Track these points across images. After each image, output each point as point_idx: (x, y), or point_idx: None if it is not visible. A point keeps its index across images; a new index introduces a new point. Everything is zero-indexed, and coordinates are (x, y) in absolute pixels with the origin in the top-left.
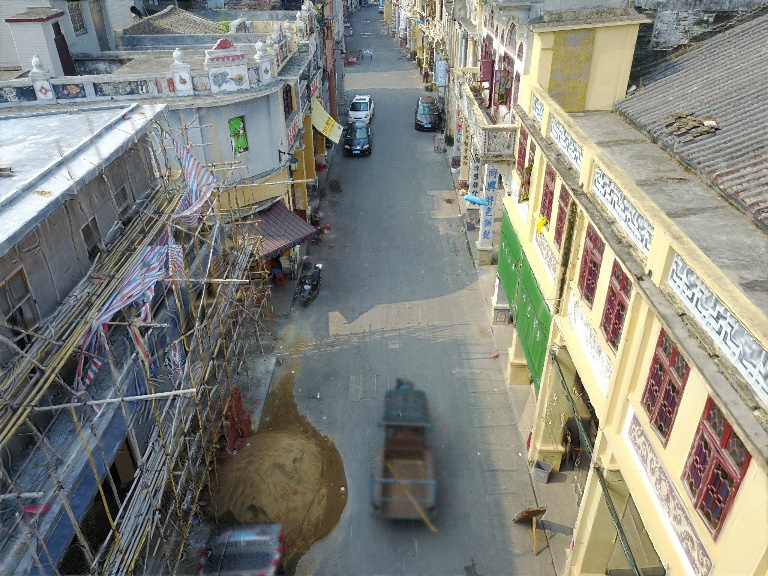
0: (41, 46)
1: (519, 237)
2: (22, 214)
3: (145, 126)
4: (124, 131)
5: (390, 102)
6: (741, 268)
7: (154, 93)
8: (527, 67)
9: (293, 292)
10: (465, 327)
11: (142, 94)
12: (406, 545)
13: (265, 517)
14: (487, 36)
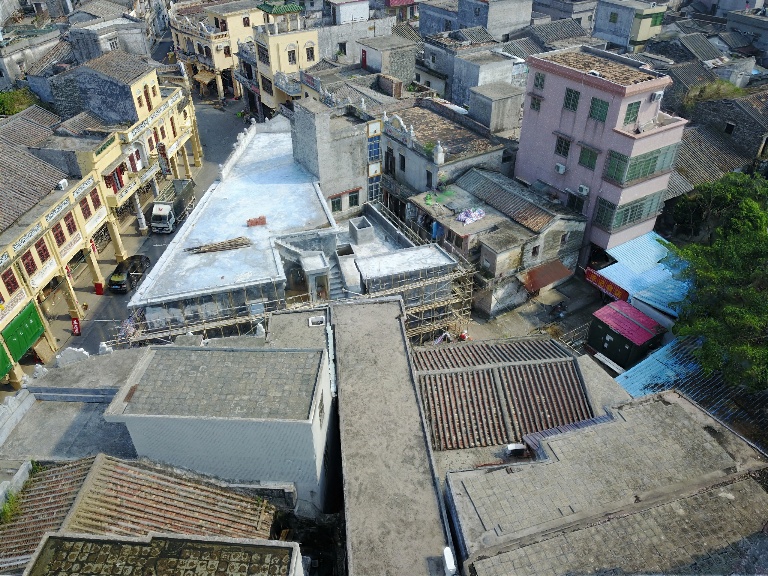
0: None
1: None
2: None
3: None
4: None
5: None
6: (23, 229)
7: None
8: None
9: None
10: None
11: None
12: None
13: None
14: None
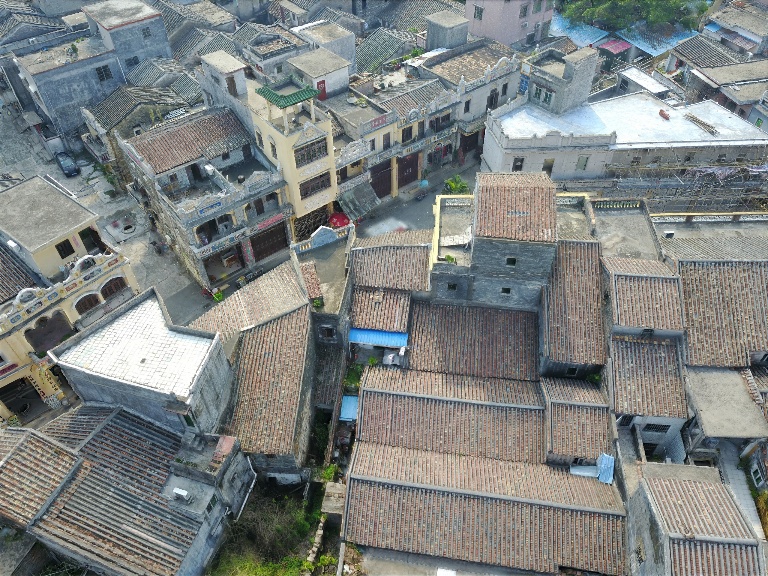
0: None
1: None
2: (701, 144)
3: (759, 145)
4: (753, 142)
5: None
6: None
7: None
8: None
9: None
10: None
11: None
12: None
13: None
14: None
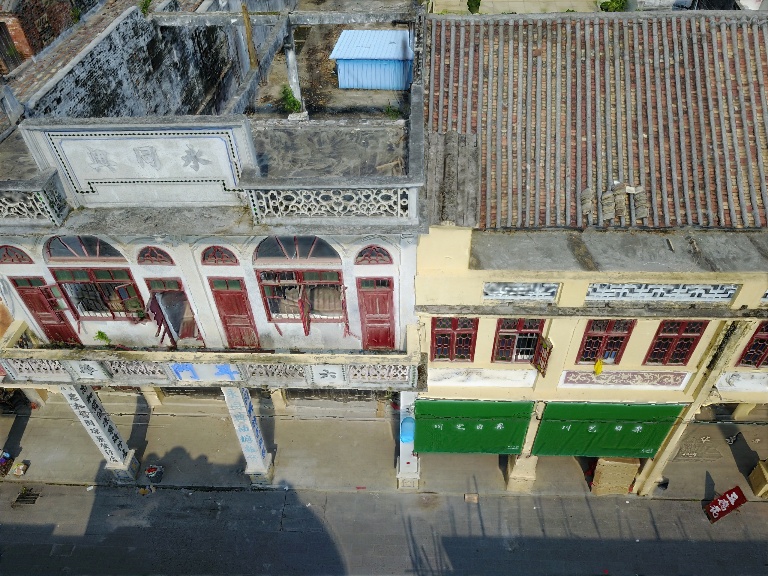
0: None
1: (539, 399)
2: None
3: None
4: None
5: None
6: None
7: None
8: (416, 264)
9: None
10: (416, 524)
11: None
12: None
13: None
14: (60, 272)
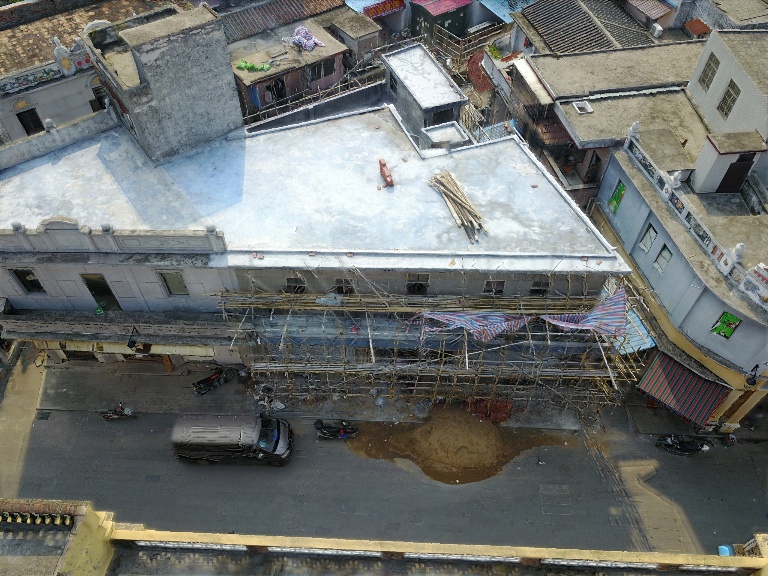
0: (710, 164)
1: None
2: (429, 264)
3: (569, 273)
4: (557, 265)
5: None
6: None
7: (709, 250)
8: None
9: (675, 433)
10: None
11: (704, 243)
12: (418, 518)
13: (429, 437)
14: None
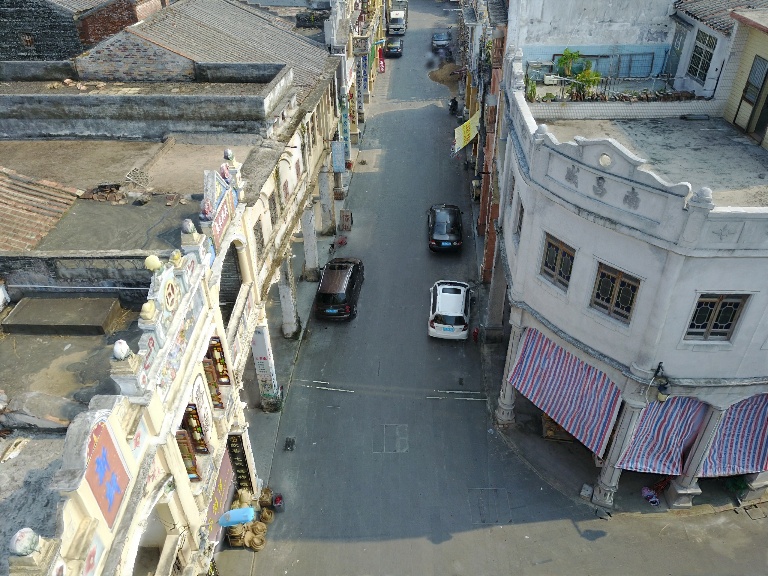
0: None
1: None
2: None
3: None
4: None
5: (393, 402)
6: None
7: None
8: None
9: None
10: None
11: None
12: None
13: None
14: (354, 6)
